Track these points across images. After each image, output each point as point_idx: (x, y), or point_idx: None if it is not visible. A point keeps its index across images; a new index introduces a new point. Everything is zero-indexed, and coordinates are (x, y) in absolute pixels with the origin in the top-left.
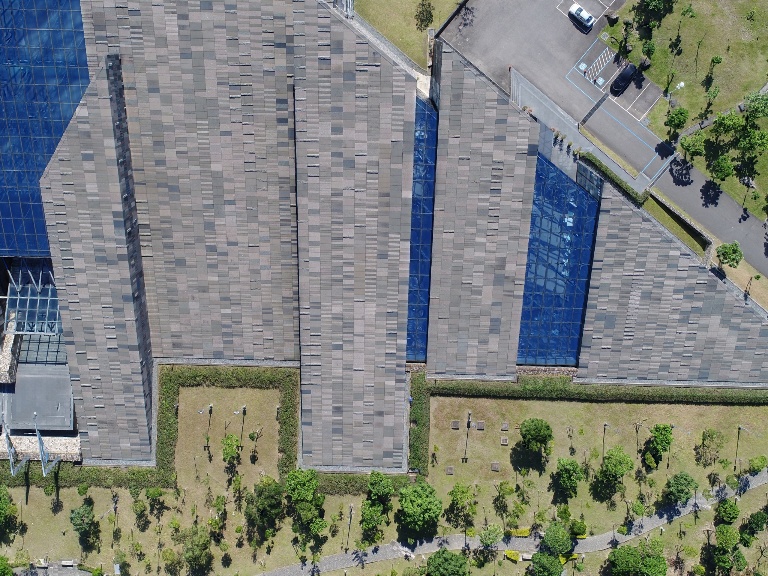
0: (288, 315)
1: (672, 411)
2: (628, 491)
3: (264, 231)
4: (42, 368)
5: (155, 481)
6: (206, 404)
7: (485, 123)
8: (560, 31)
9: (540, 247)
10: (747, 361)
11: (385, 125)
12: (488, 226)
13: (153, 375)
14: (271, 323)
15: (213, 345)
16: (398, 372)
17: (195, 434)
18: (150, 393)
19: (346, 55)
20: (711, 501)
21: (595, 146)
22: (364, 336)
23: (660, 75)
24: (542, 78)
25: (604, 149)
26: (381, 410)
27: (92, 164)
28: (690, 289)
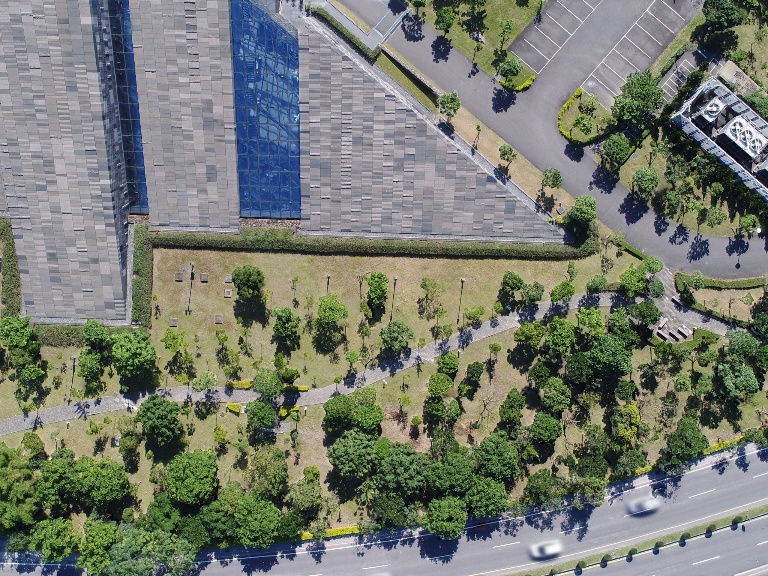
0: None
1: (396, 264)
2: (351, 344)
3: None
4: None
5: None
6: None
7: None
8: None
9: None
10: (468, 212)
11: None
12: (189, 65)
13: None
14: None
15: None
16: (106, 215)
17: None
18: None
19: None
20: (434, 354)
21: (328, 2)
22: (66, 176)
23: None
24: None
25: (337, 5)
26: (95, 257)
27: None
28: (400, 134)
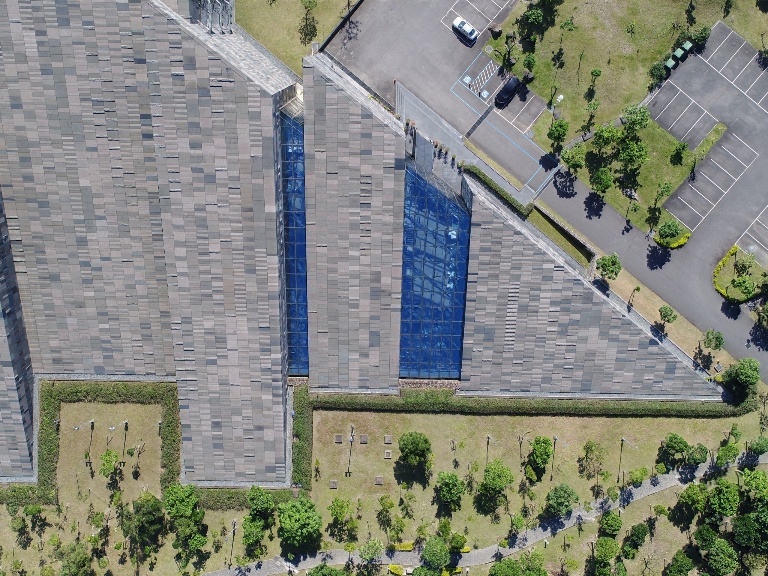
0: (167, 330)
1: (555, 423)
2: (512, 504)
3: (137, 246)
4: None
5: (36, 498)
6: (88, 420)
7: (350, 137)
8: (444, 44)
9: (415, 260)
10: (628, 373)
11: (243, 140)
12: (361, 240)
13: (34, 391)
14: (150, 338)
15: (93, 360)
16: (274, 386)
17: (77, 450)
18: (30, 409)
19: (199, 71)
20: (595, 513)
21: (479, 159)
22: (238, 351)
23: (544, 88)
24: (427, 91)
25: (489, 162)
26: (260, 425)
27: None
28: (566, 301)
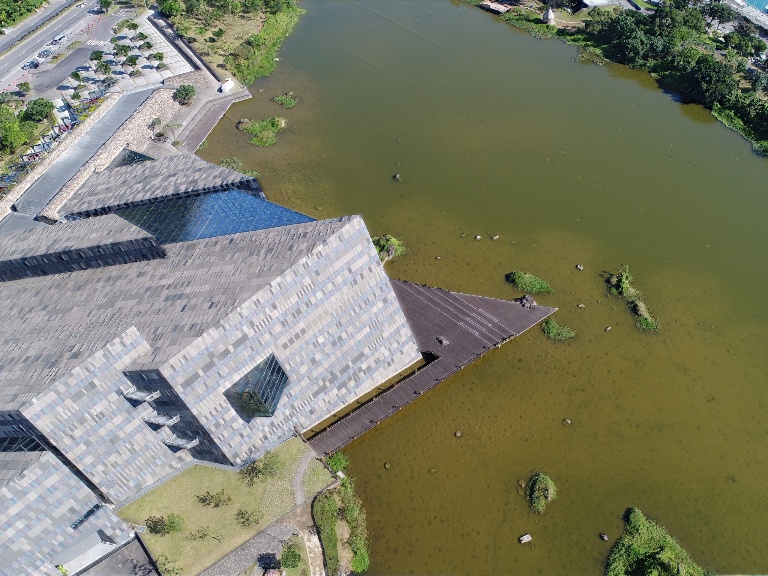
0: None
1: None
2: None
3: None
4: None
5: None
6: None
7: None
8: None
9: None
10: None
11: (6, 390)
12: None
13: None
14: None
15: None
16: None
17: None
18: None
19: (67, 361)
20: None
21: None
22: None
23: None
24: None
25: None
26: None
27: None
28: None
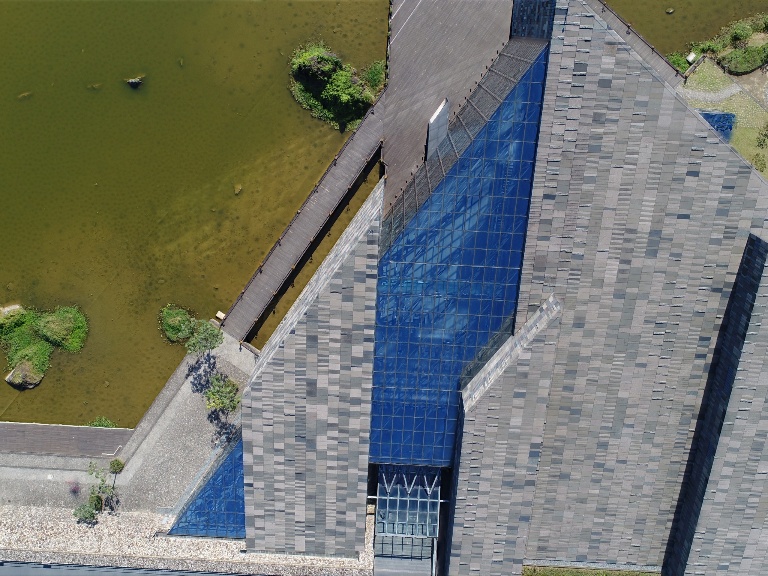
0: (660, 526)
1: None
2: None
3: (656, 452)
4: (399, 562)
5: None
6: None
7: None
8: None
9: None
10: None
11: None
12: None
13: None
14: (642, 532)
15: (578, 549)
16: None
17: None
18: None
19: None
20: None
21: None
22: (753, 559)
23: None
24: None
25: None
26: None
27: (522, 401)
28: None
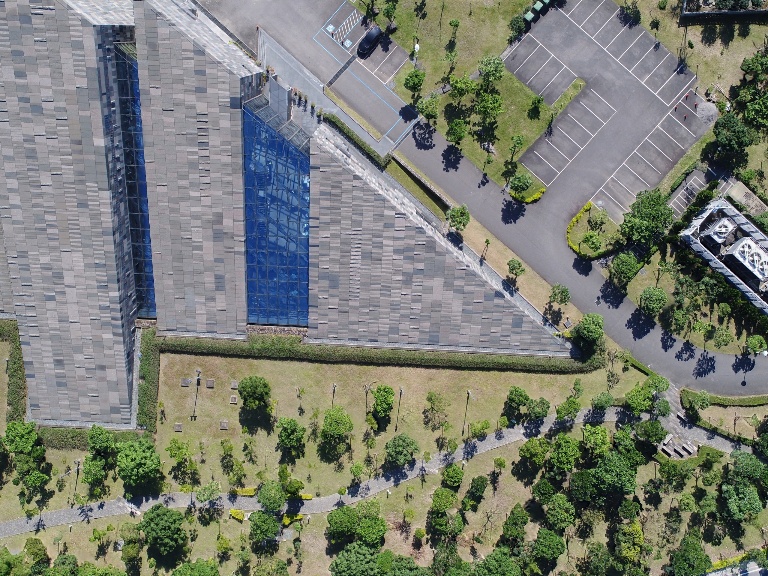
0: None
1: (402, 374)
2: (356, 453)
3: None
4: None
5: None
6: None
7: (184, 74)
8: None
9: None
10: (475, 325)
11: (68, 70)
12: (200, 180)
13: None
14: None
15: None
16: (114, 325)
17: None
18: None
19: None
20: (438, 465)
21: (339, 108)
22: (75, 287)
23: (406, 39)
24: (290, 39)
25: (349, 111)
26: (102, 364)
27: None
28: (409, 250)
